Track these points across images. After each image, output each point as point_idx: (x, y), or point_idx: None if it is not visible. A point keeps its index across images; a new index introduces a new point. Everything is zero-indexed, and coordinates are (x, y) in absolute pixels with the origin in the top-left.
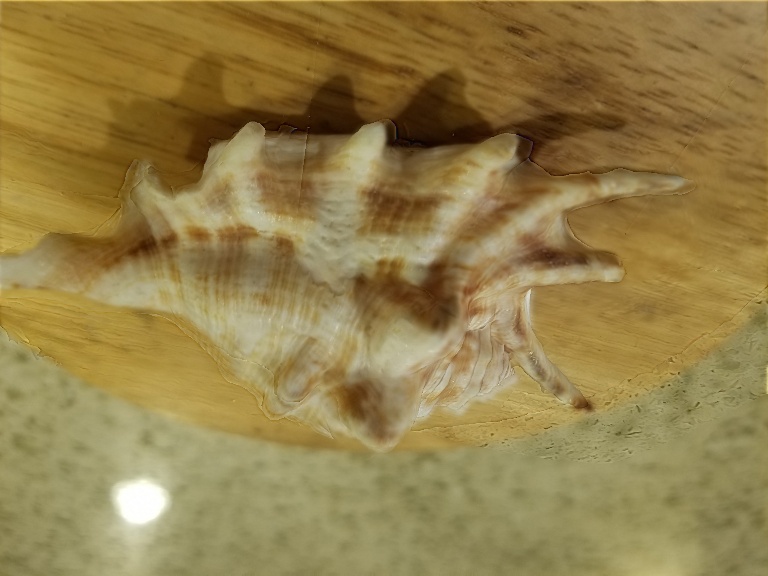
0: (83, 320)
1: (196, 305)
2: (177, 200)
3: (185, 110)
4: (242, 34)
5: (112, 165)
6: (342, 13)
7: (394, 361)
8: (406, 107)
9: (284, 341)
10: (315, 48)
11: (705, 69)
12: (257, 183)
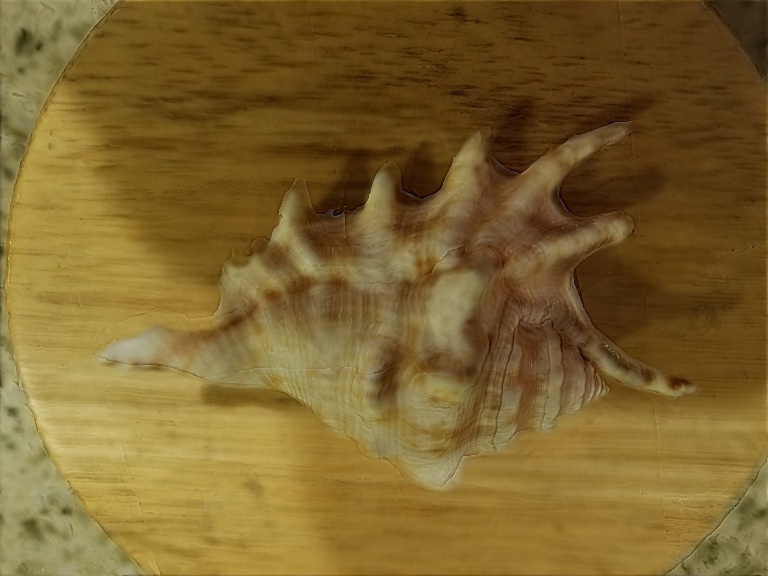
0: (207, 519)
1: (280, 325)
2: (256, 254)
3: (261, 237)
4: (287, 161)
5: (216, 308)
6: (344, 122)
7: (446, 297)
8: (410, 176)
9: (356, 332)
10: (335, 154)
11: (600, 71)
12: (310, 226)
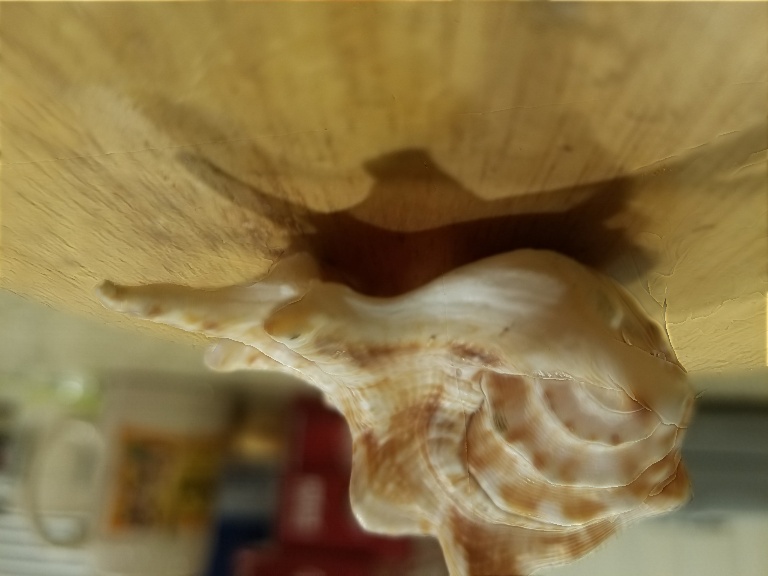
0: (713, 359)
1: None
2: None
3: None
4: None
5: None
6: None
7: None
8: None
9: None
10: None
11: (32, 189)
12: None
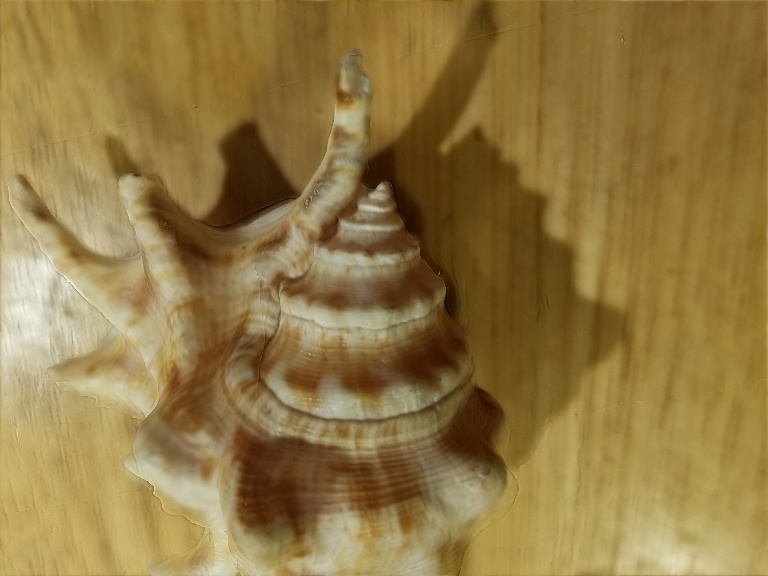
0: None
1: None
2: None
3: None
4: (172, 537)
5: None
6: (119, 480)
7: (189, 513)
8: None
9: None
10: None
11: None
12: (197, 570)
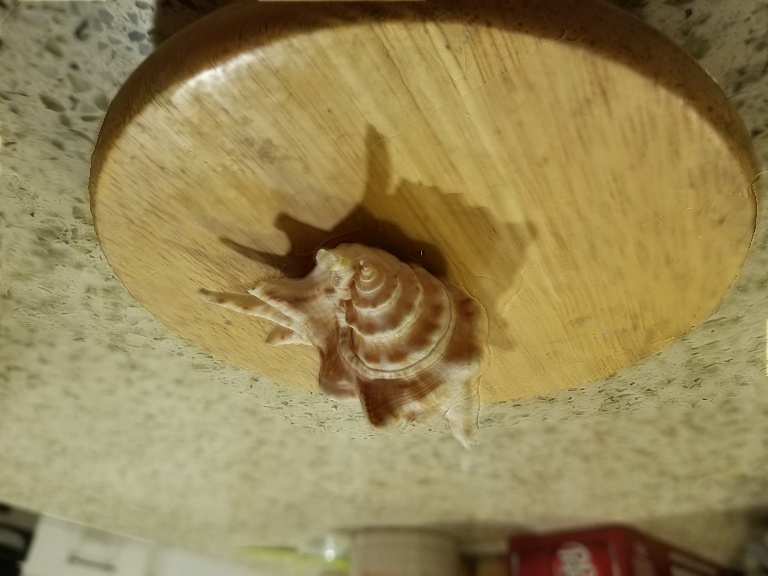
0: (618, 330)
1: None
2: None
3: None
4: None
5: None
6: None
7: None
8: None
9: None
10: None
11: None
12: None
